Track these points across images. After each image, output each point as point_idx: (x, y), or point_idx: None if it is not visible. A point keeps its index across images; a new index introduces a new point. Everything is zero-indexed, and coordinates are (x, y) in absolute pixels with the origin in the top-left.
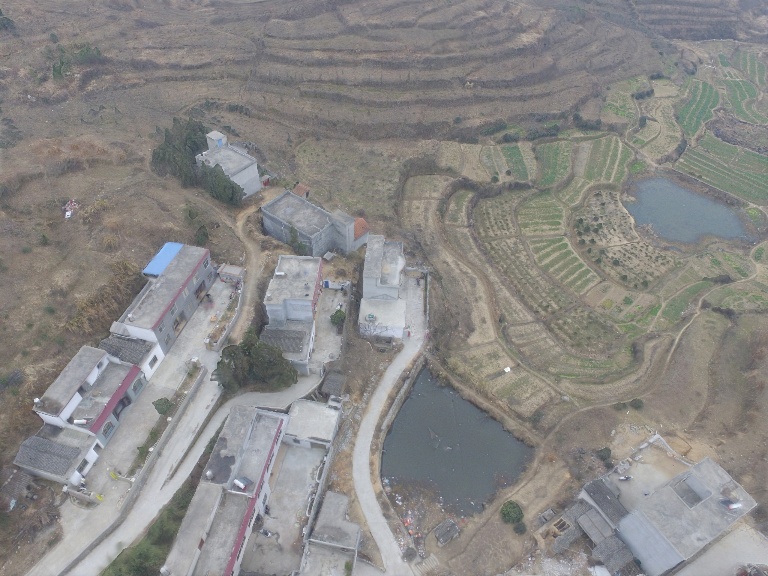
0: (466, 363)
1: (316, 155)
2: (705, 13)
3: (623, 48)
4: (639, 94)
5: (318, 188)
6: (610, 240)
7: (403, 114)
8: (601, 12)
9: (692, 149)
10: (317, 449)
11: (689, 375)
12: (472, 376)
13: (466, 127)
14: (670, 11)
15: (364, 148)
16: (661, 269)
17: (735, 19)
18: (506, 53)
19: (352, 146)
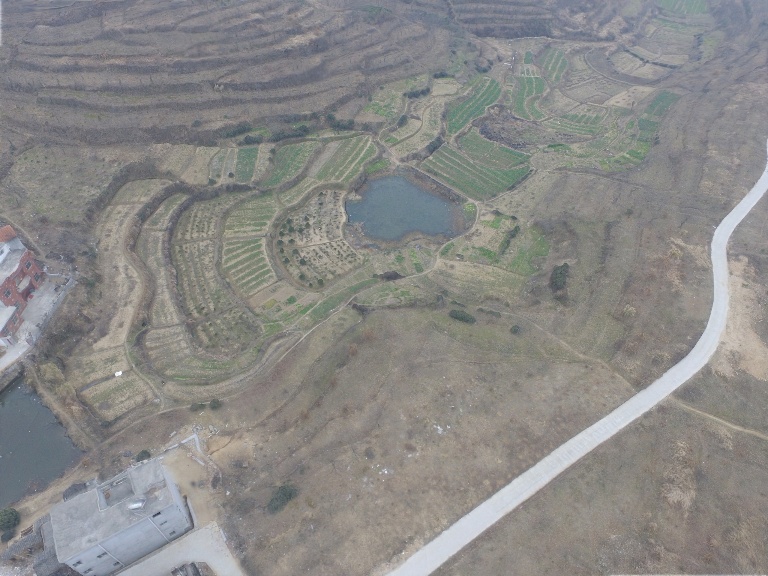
0: (78, 369)
1: (36, 162)
2: (519, 11)
3: (414, 47)
4: (411, 93)
5: (12, 195)
6: (311, 239)
7: (139, 118)
8: (419, 12)
9: (447, 146)
10: None
11: (288, 373)
12: (64, 382)
13: (204, 130)
14: (485, 10)
15: (88, 154)
16: (345, 267)
17: (549, 17)
18: (270, 55)
19: (78, 152)
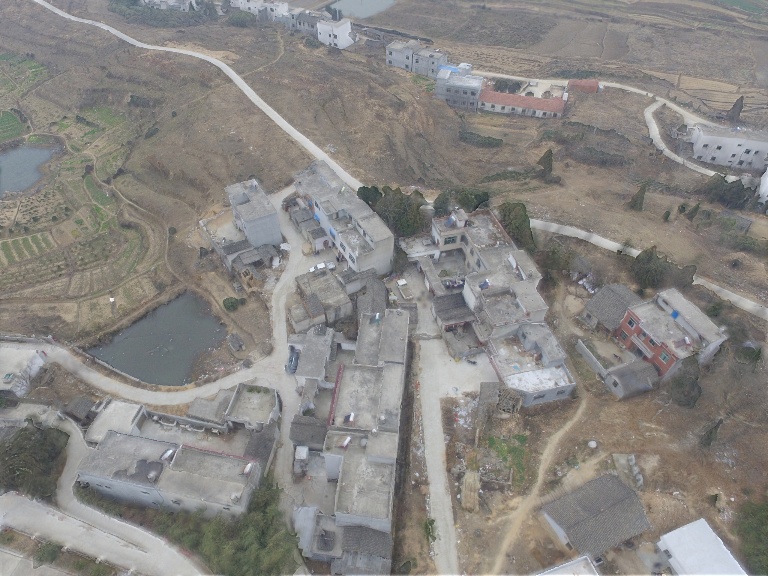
0: None
1: None
2: None
3: None
4: None
5: None
6: (7, 217)
7: None
8: None
9: None
10: (143, 427)
11: (161, 203)
12: (110, 318)
13: None
14: None
15: None
16: (58, 198)
17: None
18: None
19: None
